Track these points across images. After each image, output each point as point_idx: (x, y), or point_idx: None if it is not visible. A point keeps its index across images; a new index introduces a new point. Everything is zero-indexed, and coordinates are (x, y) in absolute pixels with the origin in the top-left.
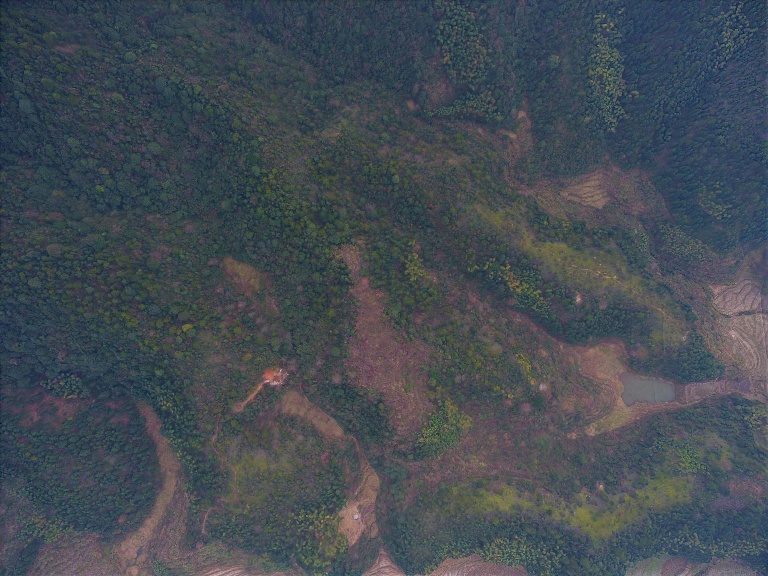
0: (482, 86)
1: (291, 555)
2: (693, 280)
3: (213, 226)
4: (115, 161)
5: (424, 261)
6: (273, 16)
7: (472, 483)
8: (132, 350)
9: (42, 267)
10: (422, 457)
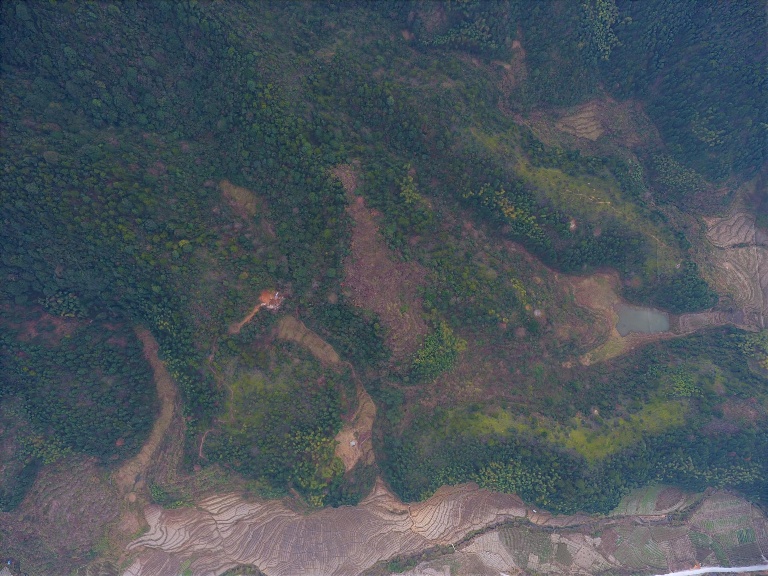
0: (476, 13)
1: (288, 478)
2: (687, 212)
3: (209, 147)
4: (112, 75)
5: (419, 187)
6: None
7: (467, 407)
8: (129, 265)
9: (39, 173)
10: (418, 380)
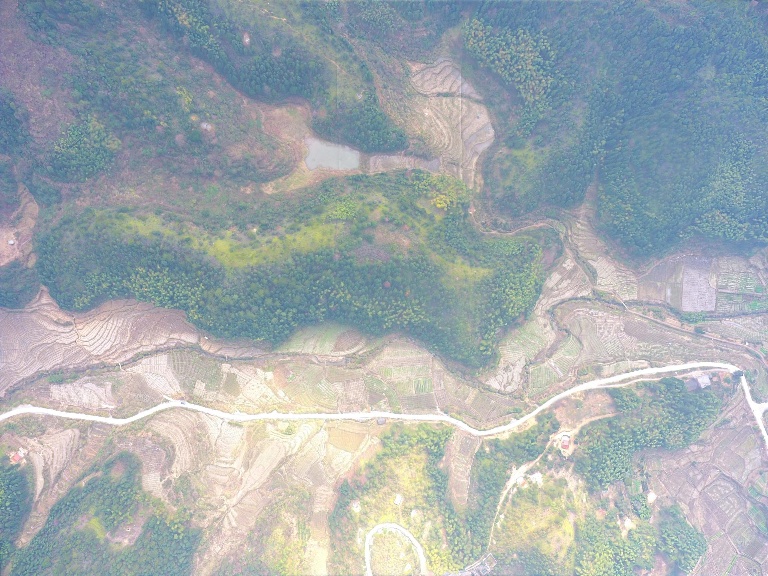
0: None
1: None
2: (392, 55)
3: None
4: None
5: None
6: None
7: (118, 208)
8: None
9: None
10: (66, 174)
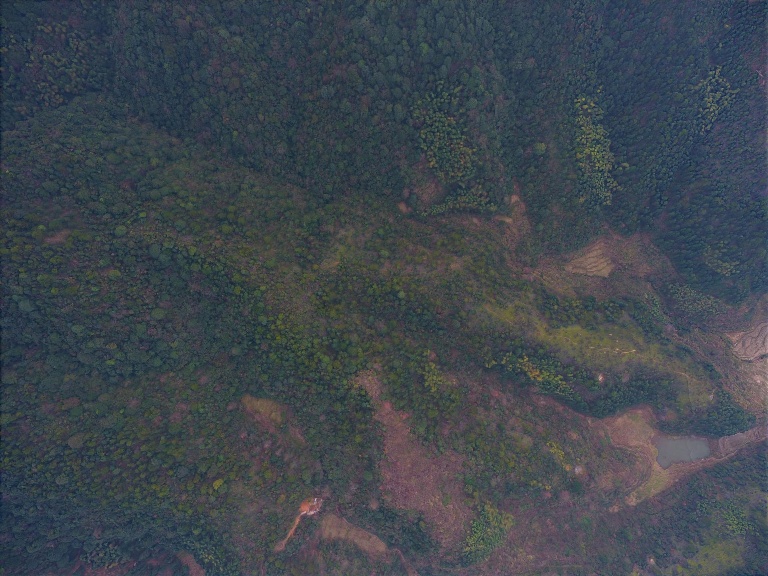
0: (472, 182)
1: None
2: (710, 331)
3: (227, 371)
4: (121, 334)
5: (441, 365)
6: (253, 148)
7: None
8: (167, 515)
9: (67, 462)
10: (470, 563)
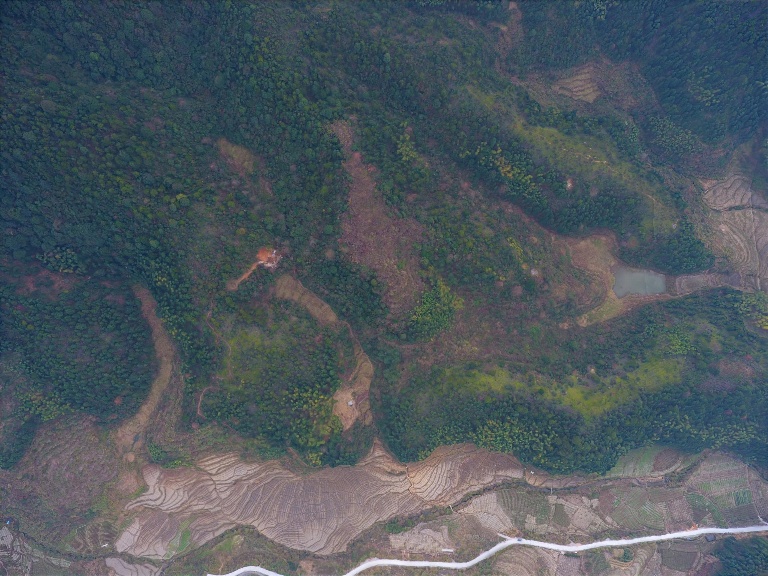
0: None
1: (286, 436)
2: (683, 175)
3: (207, 104)
4: (109, 28)
5: (416, 146)
6: None
7: (465, 365)
8: (127, 220)
9: (37, 122)
10: (415, 338)
